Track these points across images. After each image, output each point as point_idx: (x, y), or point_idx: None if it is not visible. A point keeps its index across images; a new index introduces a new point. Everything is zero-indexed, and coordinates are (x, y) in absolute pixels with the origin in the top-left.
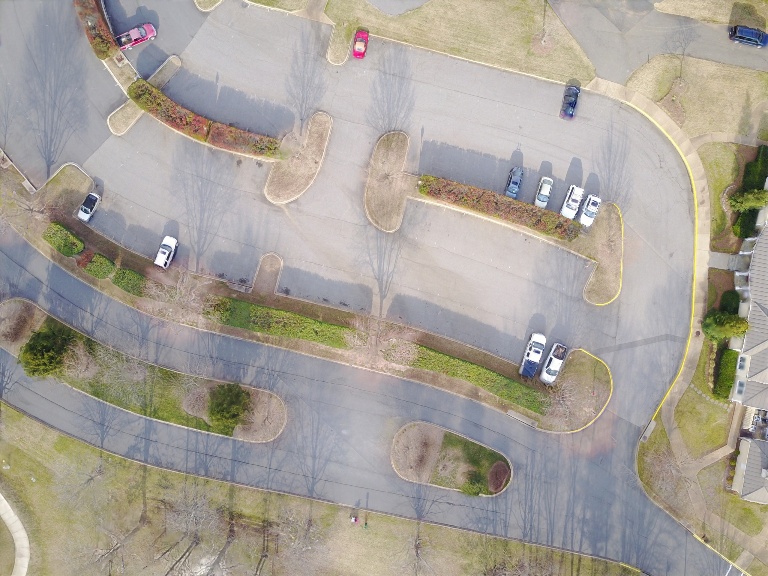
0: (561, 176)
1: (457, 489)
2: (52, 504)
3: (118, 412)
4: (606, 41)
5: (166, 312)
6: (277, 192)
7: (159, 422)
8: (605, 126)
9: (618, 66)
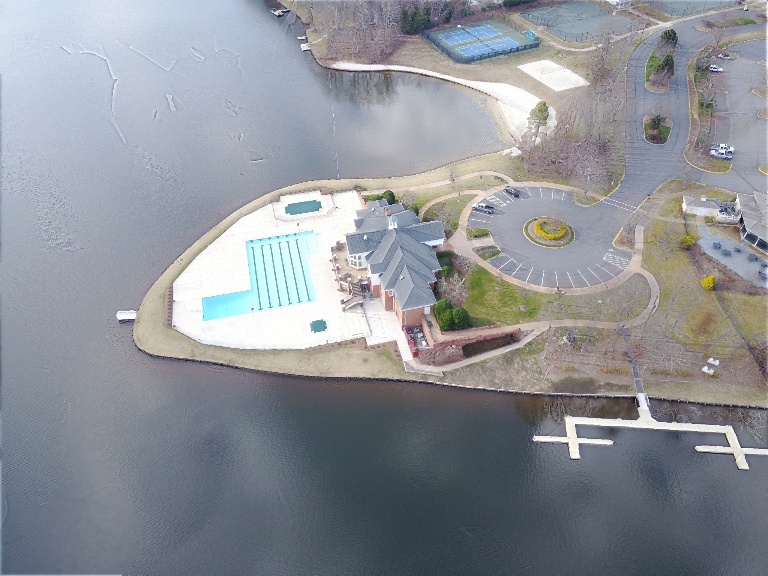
0: None
1: None
2: None
3: None
4: None
5: None
6: None
7: None
8: None
9: None
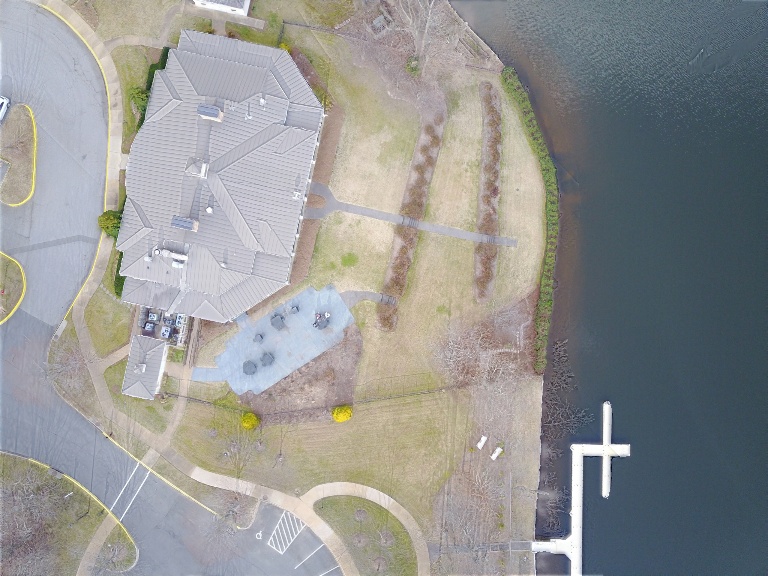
0: None
1: None
2: None
3: None
4: None
5: None
6: None
7: None
8: (21, 29)
9: None
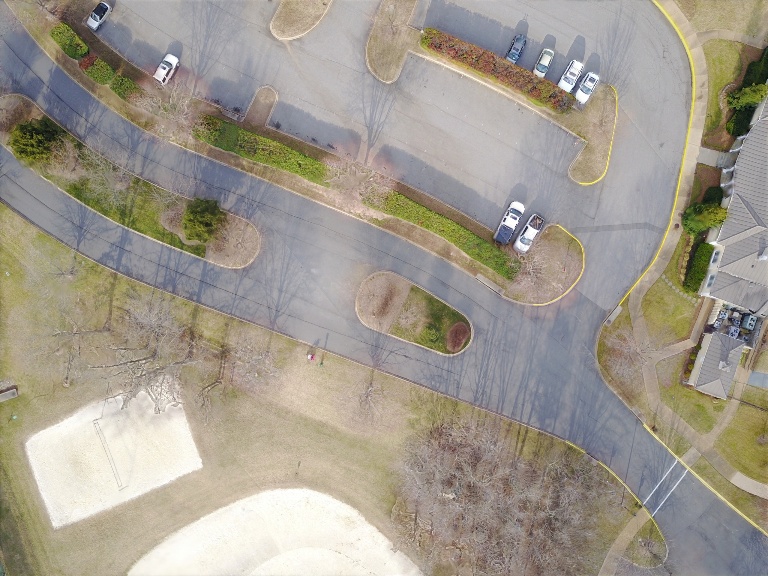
0: (563, 52)
1: (416, 343)
2: (22, 300)
3: (98, 218)
4: None
5: (158, 128)
6: (282, 27)
7: (136, 233)
8: (614, 9)
9: None
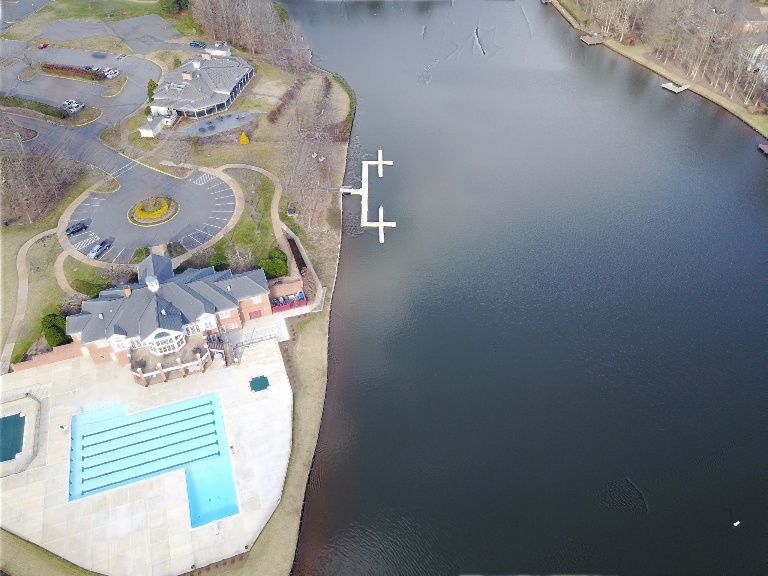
0: None
1: (6, 139)
2: None
3: None
4: (142, 47)
5: None
6: None
7: None
8: None
9: (144, 51)
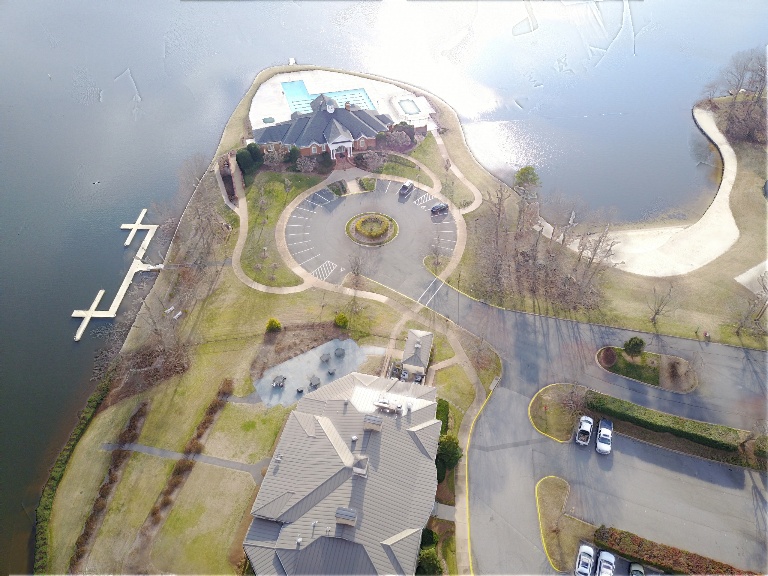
0: None
1: None
2: None
3: None
4: None
5: None
6: None
7: None
8: None
9: None
